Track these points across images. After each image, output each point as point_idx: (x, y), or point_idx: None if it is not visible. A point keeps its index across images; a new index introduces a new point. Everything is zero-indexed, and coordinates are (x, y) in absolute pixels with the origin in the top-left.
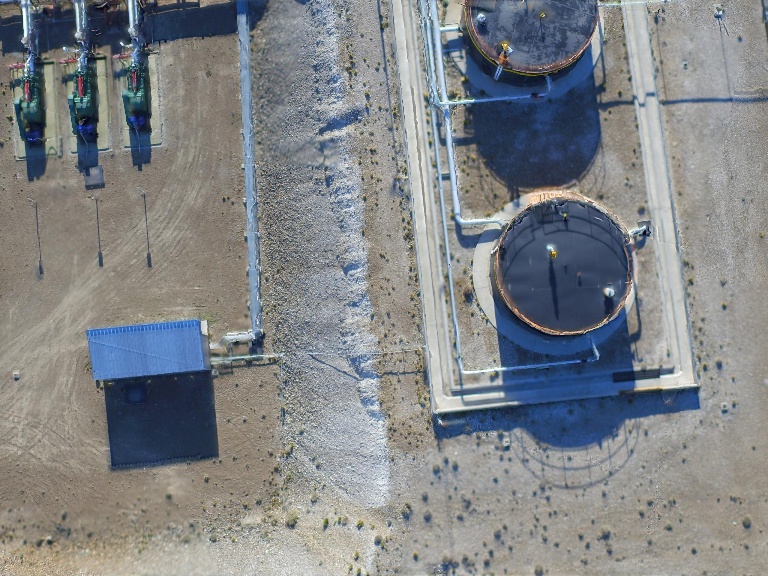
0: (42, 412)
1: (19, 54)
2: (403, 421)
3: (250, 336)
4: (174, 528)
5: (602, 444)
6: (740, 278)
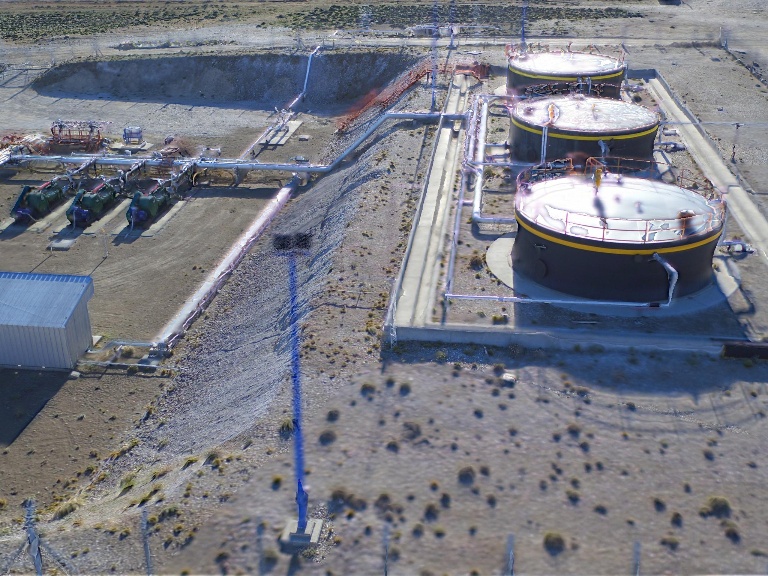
0: None
1: None
2: (331, 342)
3: (150, 343)
4: None
5: (698, 399)
6: None
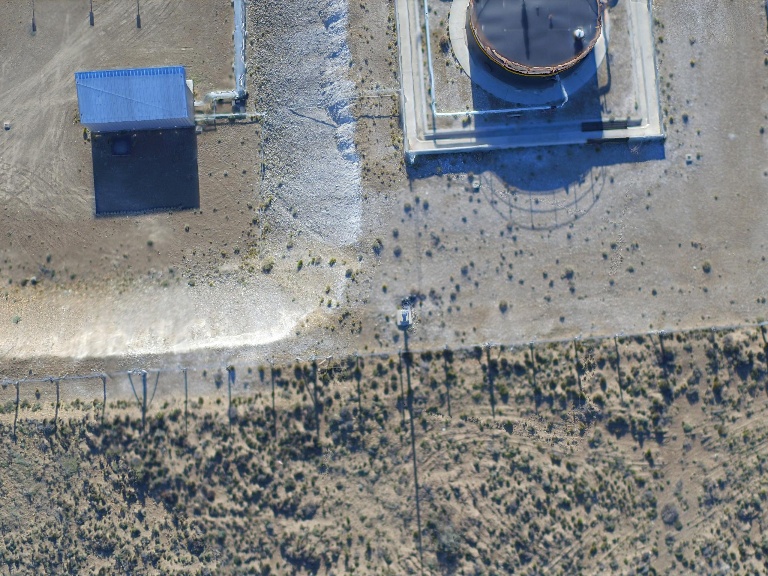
0: (31, 160)
1: None
2: (377, 161)
3: (233, 94)
4: (154, 273)
5: (569, 189)
6: (709, 38)
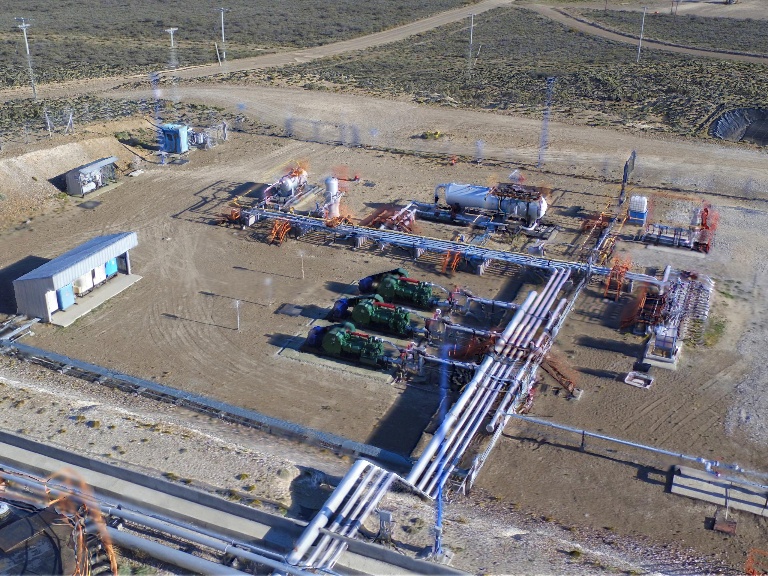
0: None
1: None
2: None
3: (6, 336)
4: None
5: None
6: None
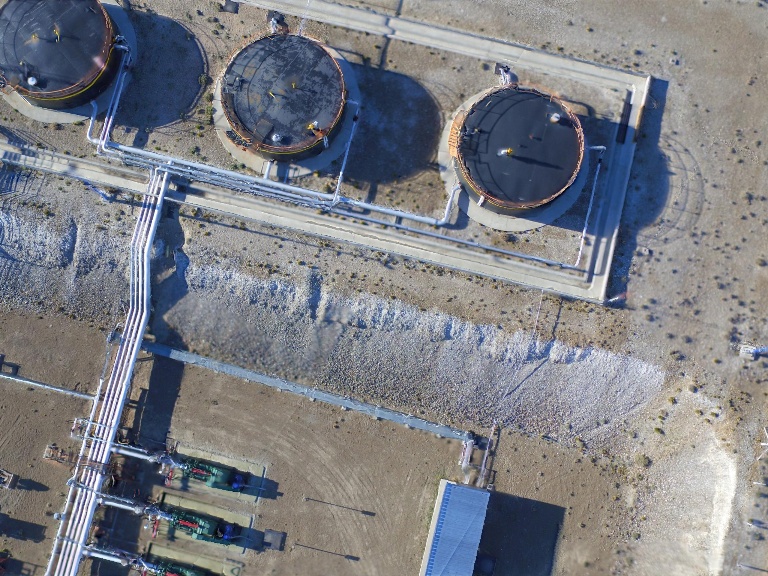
0: None
1: (131, 574)
2: (599, 332)
3: (470, 444)
4: (616, 569)
5: (673, 172)
6: (571, 8)
